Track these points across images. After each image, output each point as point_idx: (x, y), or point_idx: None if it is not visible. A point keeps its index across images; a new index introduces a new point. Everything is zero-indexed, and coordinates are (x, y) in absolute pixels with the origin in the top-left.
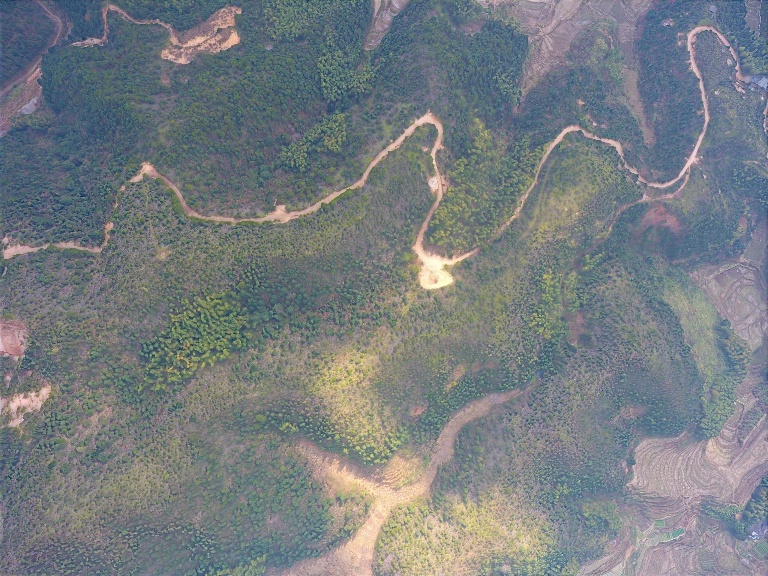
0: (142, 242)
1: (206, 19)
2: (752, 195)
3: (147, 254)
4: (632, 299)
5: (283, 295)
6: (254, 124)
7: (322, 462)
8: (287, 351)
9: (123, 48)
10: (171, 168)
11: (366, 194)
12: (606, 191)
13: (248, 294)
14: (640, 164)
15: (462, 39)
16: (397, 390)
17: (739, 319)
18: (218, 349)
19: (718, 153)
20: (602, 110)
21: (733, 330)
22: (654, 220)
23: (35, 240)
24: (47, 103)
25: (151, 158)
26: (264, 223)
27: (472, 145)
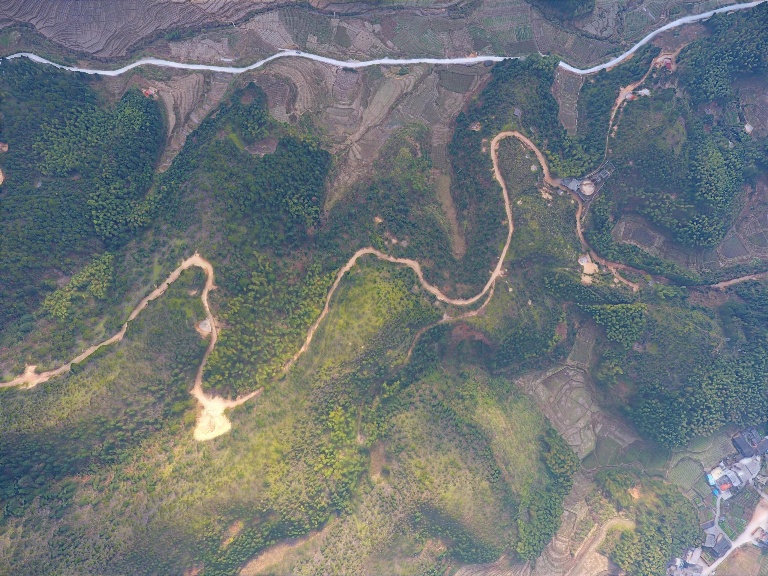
0: None
1: None
2: (570, 299)
3: None
4: (433, 427)
5: (29, 467)
6: (8, 276)
7: None
8: (30, 530)
9: None
10: None
11: (121, 350)
12: (393, 321)
13: None
14: (442, 281)
15: (249, 162)
16: (158, 559)
17: (570, 423)
18: None
19: (525, 263)
20: (405, 224)
21: (561, 437)
22: (464, 335)
23: None
24: None
25: None
26: (7, 391)
27: (250, 281)
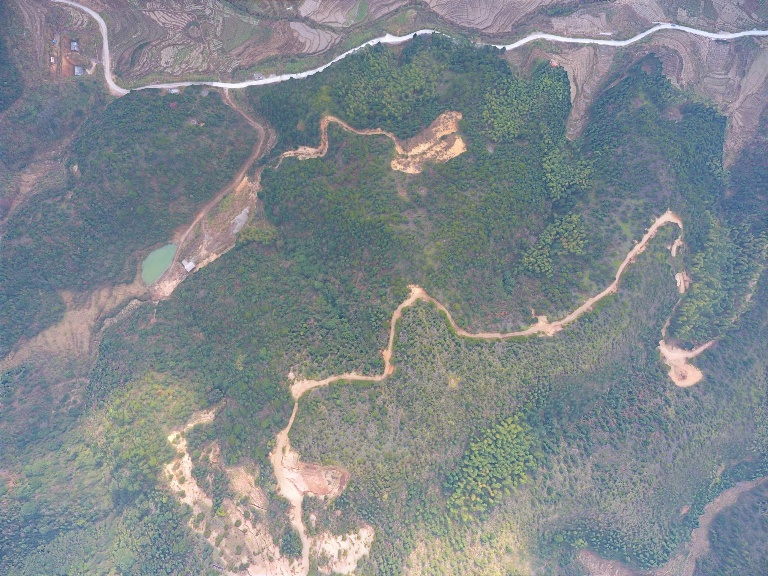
0: (434, 371)
1: (428, 126)
2: None
3: (441, 384)
4: None
5: (559, 409)
6: (500, 234)
7: (598, 569)
8: (572, 466)
9: (354, 162)
10: (439, 289)
11: (625, 300)
12: None
13: (533, 413)
14: None
15: (673, 127)
16: (675, 495)
17: None
18: (516, 473)
19: None
20: None
21: None
22: None
23: (319, 373)
24: (268, 215)
25: (420, 281)
26: (533, 338)
27: None
